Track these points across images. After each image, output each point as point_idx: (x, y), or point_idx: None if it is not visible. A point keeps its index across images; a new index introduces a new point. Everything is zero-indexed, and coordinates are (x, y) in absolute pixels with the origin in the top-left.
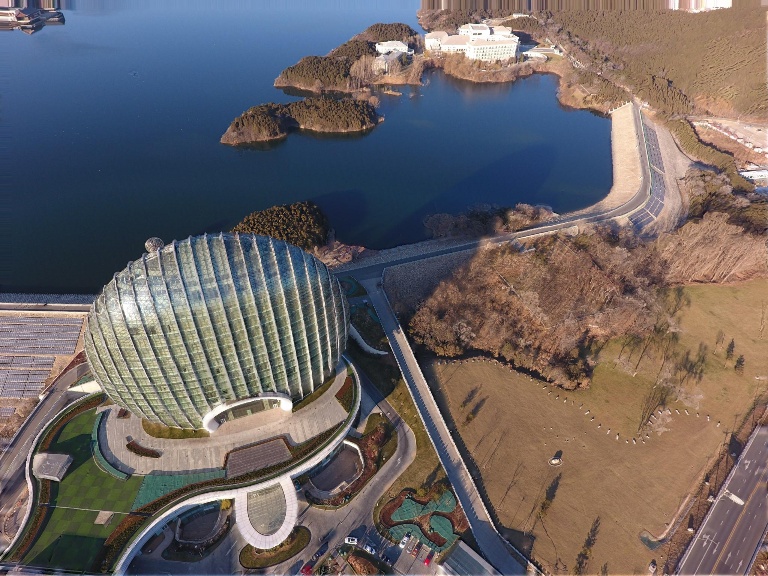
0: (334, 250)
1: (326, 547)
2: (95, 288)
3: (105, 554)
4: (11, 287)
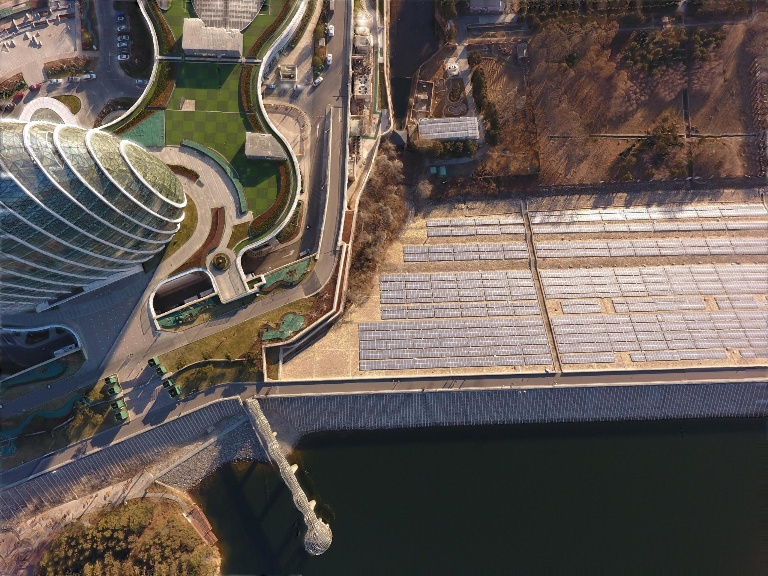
0: (27, 564)
1: (3, 114)
2: (388, 444)
3: (170, 74)
4: (516, 438)
